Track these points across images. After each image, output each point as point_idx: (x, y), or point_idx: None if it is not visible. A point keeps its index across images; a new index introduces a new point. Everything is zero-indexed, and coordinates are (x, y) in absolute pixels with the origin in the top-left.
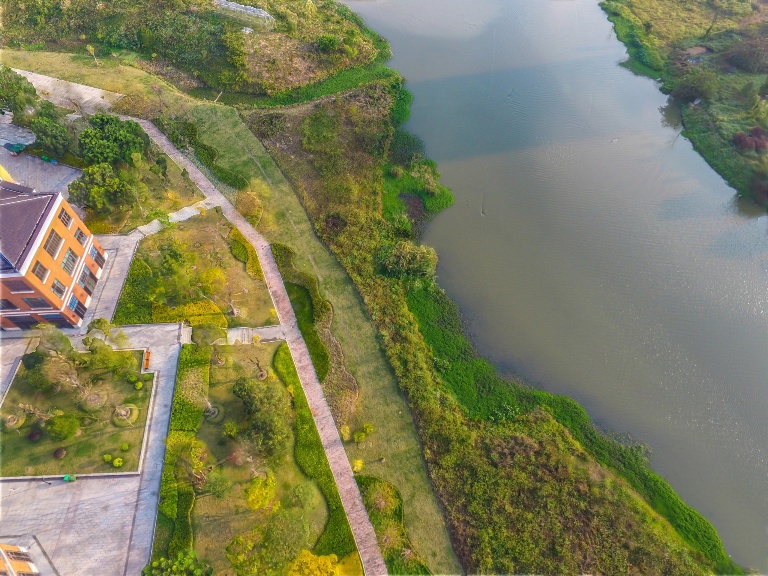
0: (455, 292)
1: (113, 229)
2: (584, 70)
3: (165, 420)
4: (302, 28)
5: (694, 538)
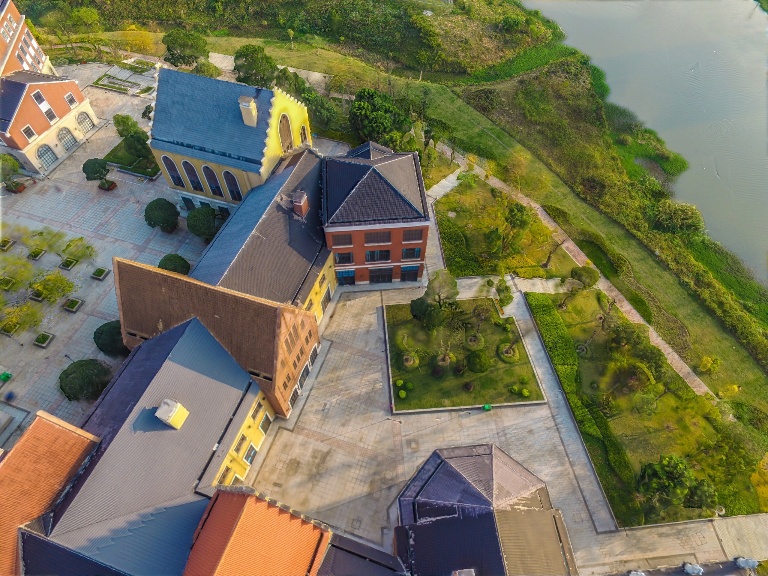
0: (729, 244)
1: None
2: (751, 45)
3: (543, 357)
4: (476, 10)
5: None
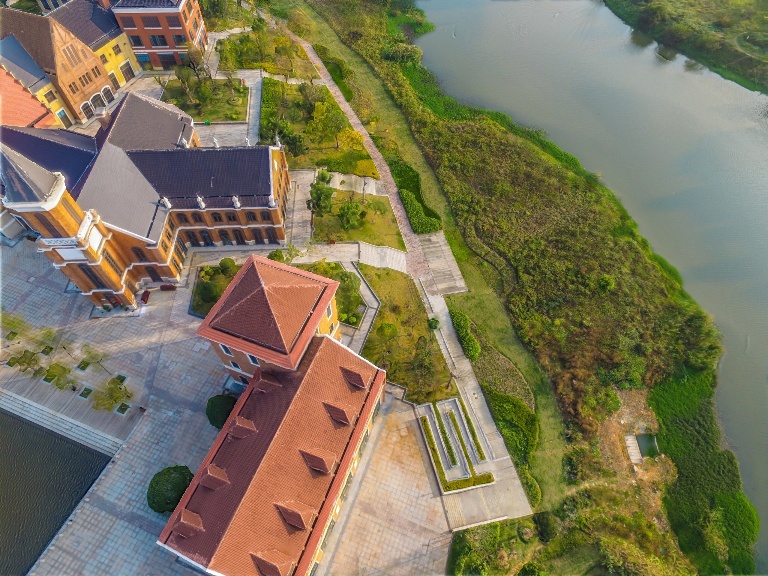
0: (433, 69)
1: (210, 30)
2: None
3: (258, 105)
4: None
5: (565, 162)
